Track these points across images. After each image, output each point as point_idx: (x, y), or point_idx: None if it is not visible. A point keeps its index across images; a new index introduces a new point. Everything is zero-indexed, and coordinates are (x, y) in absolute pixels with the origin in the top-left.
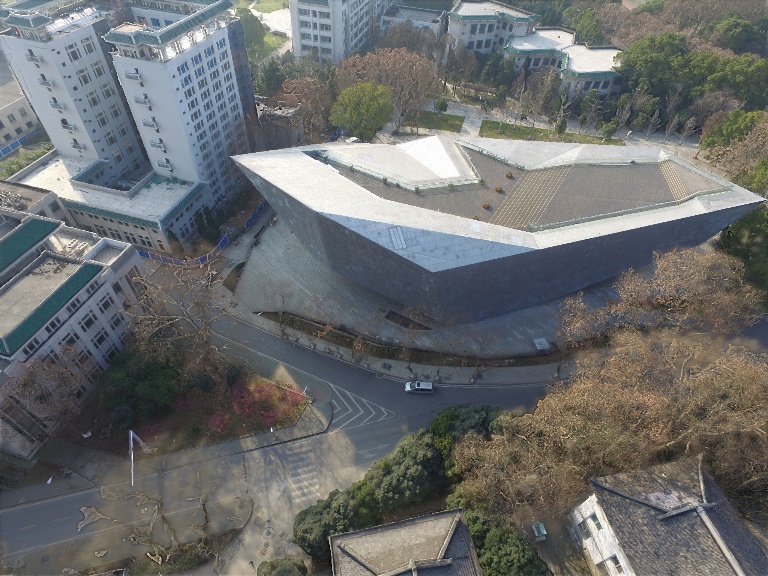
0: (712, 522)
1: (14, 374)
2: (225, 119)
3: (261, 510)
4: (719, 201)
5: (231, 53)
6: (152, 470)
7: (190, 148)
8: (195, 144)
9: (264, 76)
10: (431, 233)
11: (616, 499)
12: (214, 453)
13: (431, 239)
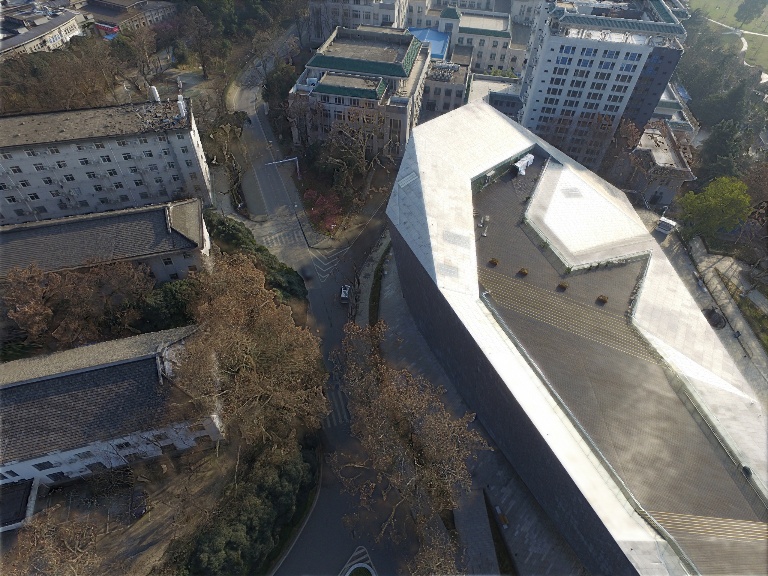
0: (147, 371)
1: (312, 102)
2: (589, 118)
3: (260, 225)
4: None
5: (642, 72)
6: (286, 182)
7: (530, 109)
8: (537, 110)
9: (711, 134)
10: (421, 198)
11: (190, 331)
12: (295, 202)
13: (415, 200)
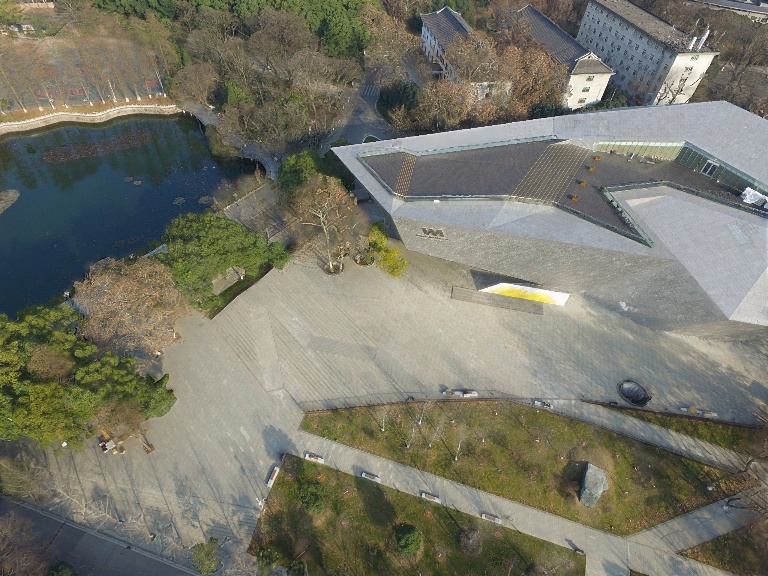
0: None
1: None
2: None
3: None
4: (382, 147)
5: None
6: None
7: None
8: None
9: None
10: None
11: None
12: None
13: None
